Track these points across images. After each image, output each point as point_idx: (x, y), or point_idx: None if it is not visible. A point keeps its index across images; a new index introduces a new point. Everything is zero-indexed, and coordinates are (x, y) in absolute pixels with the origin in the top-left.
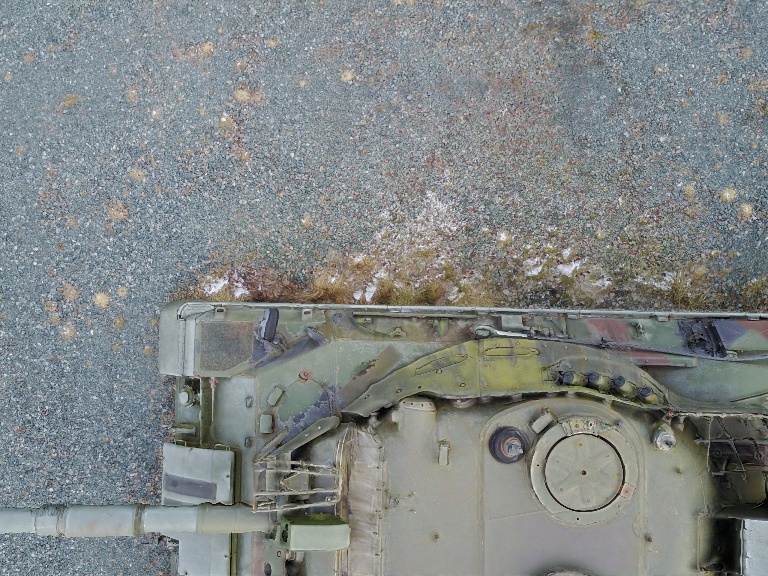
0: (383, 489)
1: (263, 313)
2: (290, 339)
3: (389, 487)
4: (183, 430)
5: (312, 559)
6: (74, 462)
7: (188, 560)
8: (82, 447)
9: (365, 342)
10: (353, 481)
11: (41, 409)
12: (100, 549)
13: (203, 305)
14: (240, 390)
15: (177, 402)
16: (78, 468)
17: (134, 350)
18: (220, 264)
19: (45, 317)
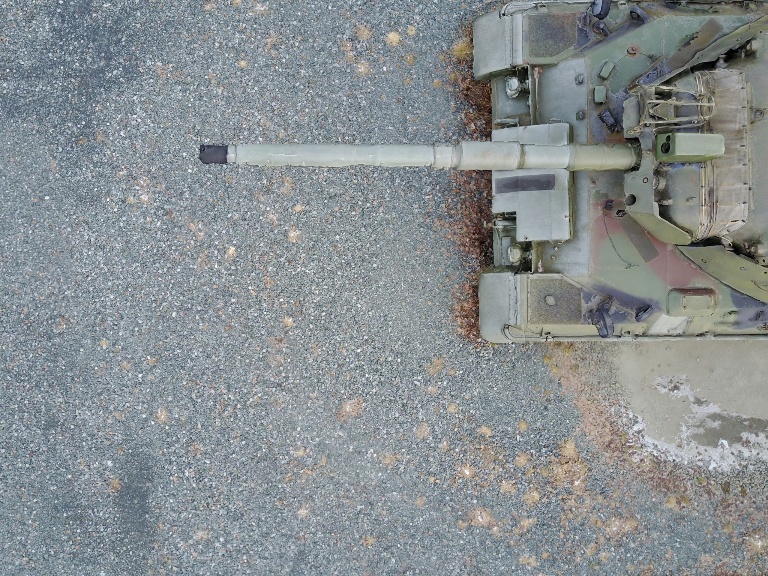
0: (748, 107)
1: (581, 7)
2: (611, 26)
3: (753, 104)
4: (508, 120)
5: (676, 182)
6: (373, 187)
7: (527, 226)
8: (380, 173)
9: (688, 17)
10: (715, 107)
11: (342, 139)
12: (400, 266)
13: (525, 3)
14: (569, 72)
15: (494, 102)
16: (377, 193)
17: (424, 84)
18: (500, 3)
19: (341, 56)
